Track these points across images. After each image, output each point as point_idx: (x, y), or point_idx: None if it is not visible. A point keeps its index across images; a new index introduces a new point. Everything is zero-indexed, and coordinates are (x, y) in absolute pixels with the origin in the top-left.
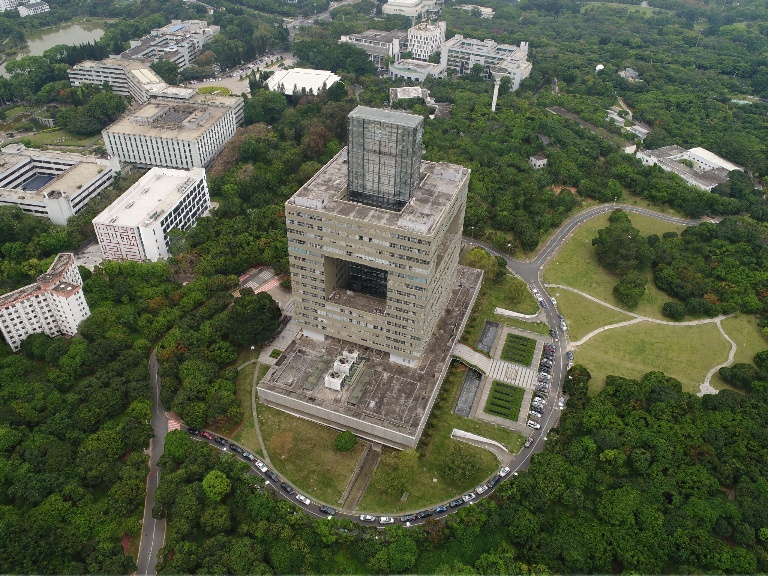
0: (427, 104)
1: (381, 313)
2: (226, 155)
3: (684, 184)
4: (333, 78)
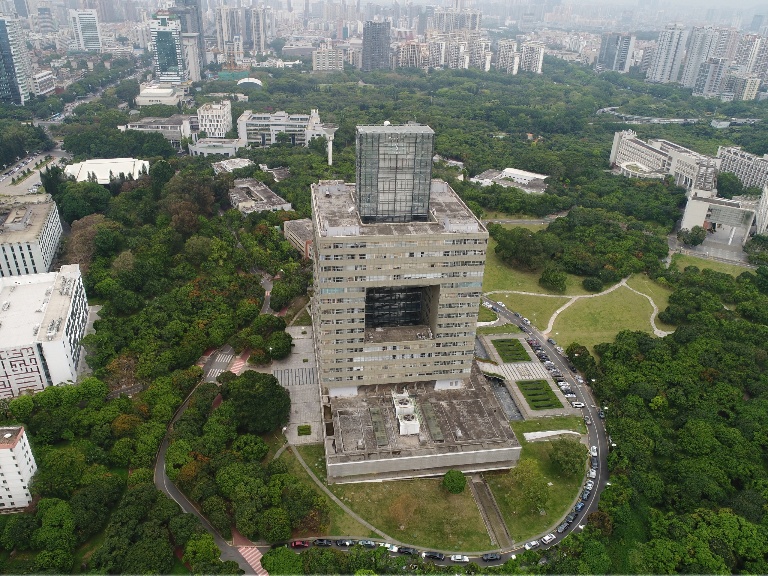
0: (261, 171)
1: (427, 337)
2: (81, 250)
3: (525, 193)
4: (140, 163)
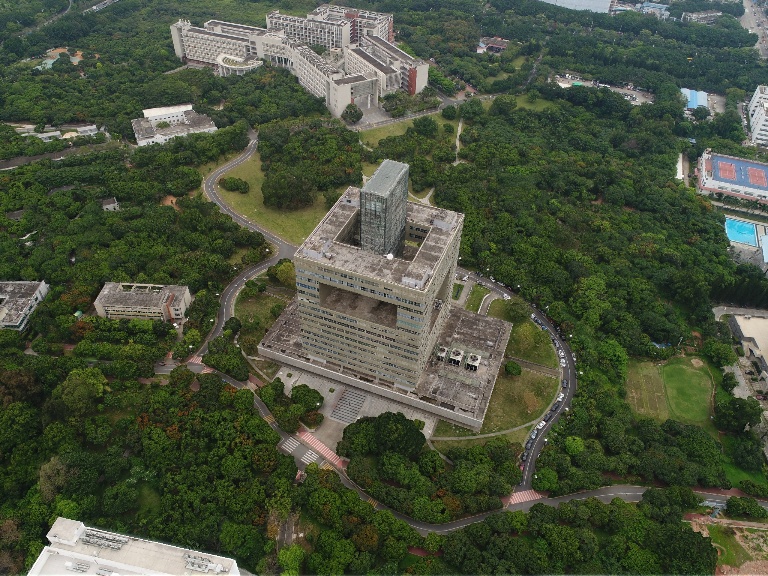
0: None
1: None
2: None
3: (210, 135)
4: None
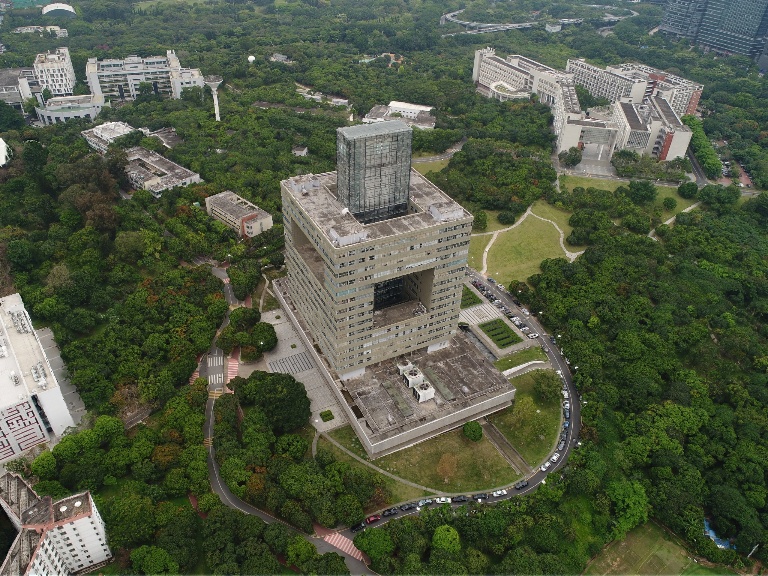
0: None
1: (422, 312)
2: None
3: (420, 130)
4: None
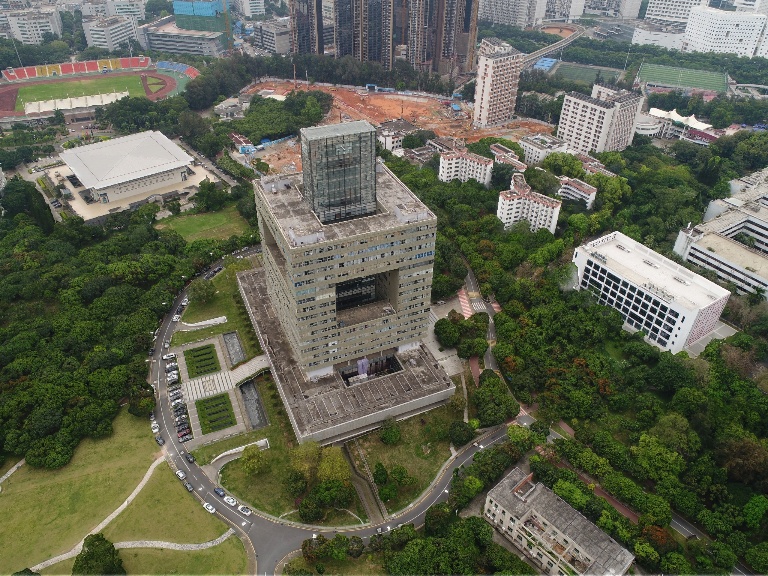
0: None
1: None
2: None
3: None
4: None
